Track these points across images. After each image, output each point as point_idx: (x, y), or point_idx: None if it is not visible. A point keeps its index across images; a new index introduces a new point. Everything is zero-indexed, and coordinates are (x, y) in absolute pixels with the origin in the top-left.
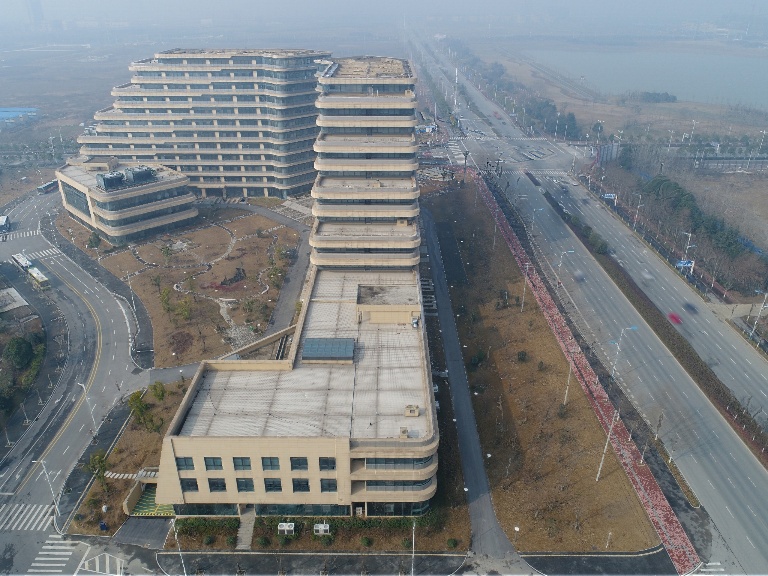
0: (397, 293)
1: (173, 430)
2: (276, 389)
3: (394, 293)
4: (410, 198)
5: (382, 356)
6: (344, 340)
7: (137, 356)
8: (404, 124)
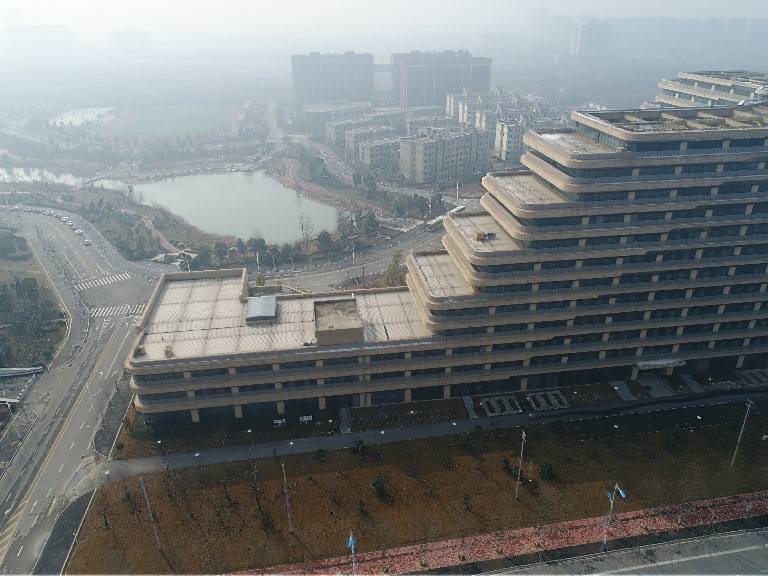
0: (344, 319)
1: (178, 277)
2: (216, 300)
3: (344, 318)
4: (469, 260)
5: (257, 336)
6: (271, 311)
7: (348, 280)
8: (559, 184)
